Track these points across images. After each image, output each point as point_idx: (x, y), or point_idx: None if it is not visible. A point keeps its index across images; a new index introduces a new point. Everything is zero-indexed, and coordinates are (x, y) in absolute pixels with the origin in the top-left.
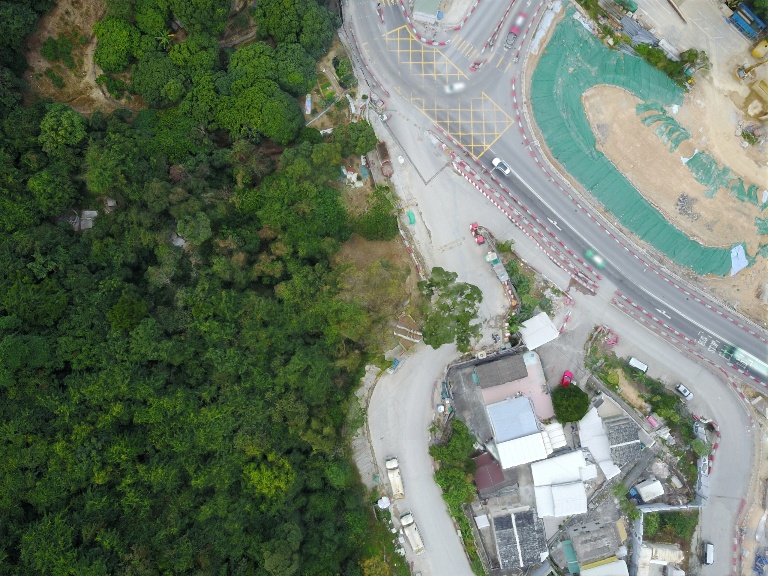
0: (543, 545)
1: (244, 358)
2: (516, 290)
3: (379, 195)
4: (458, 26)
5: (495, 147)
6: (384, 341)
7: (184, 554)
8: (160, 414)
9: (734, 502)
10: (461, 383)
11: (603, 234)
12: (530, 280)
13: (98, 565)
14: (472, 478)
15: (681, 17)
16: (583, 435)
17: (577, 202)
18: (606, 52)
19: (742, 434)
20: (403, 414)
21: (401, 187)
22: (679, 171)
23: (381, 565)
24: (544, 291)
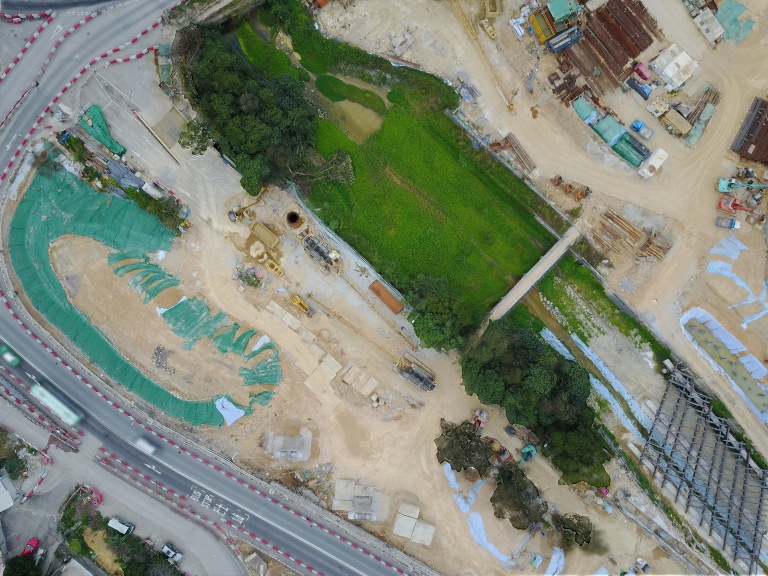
0: None
1: None
2: None
3: None
4: None
5: None
6: None
7: None
8: None
9: None
10: None
11: (86, 387)
12: None
13: None
14: None
15: (174, 158)
16: None
17: (56, 355)
18: (93, 196)
19: None
20: None
21: None
22: (154, 323)
23: None
24: (18, 451)
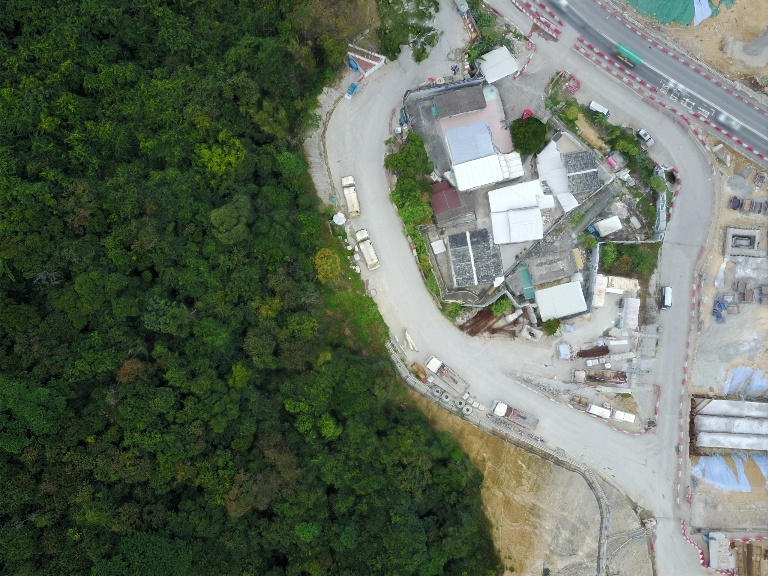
0: (499, 270)
1: (196, 42)
2: (476, 22)
3: None
4: None
5: None
6: (336, 27)
7: (129, 197)
8: (110, 79)
9: (694, 250)
10: (420, 116)
11: None
12: (492, 22)
13: (40, 185)
14: (428, 198)
15: None
16: (541, 169)
17: None
18: None
19: (703, 183)
20: (361, 139)
21: None
22: None
23: (332, 257)
24: (506, 35)
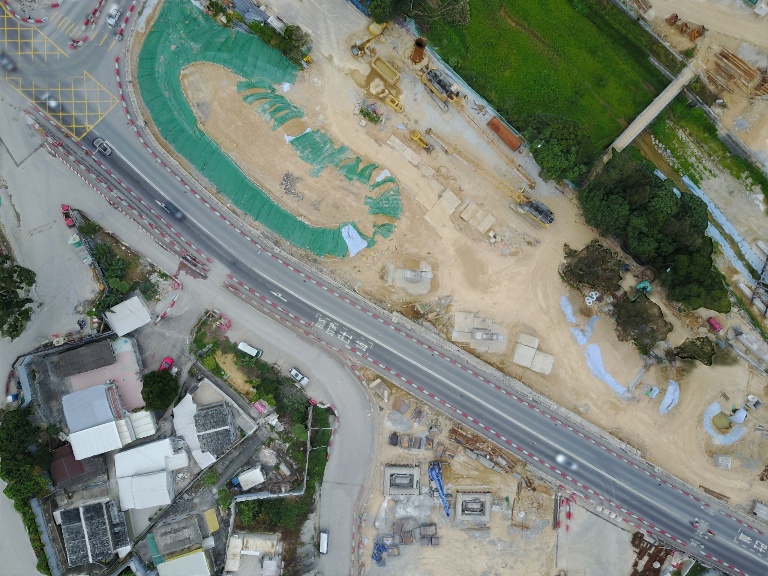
0: (124, 539)
1: None
2: (103, 274)
3: None
4: (56, 3)
5: (98, 127)
6: None
7: None
8: None
9: (354, 489)
10: (48, 372)
11: (214, 216)
12: (133, 264)
13: None
14: (41, 471)
15: None
16: (177, 423)
17: (185, 183)
18: (218, 30)
19: (362, 418)
20: None
21: None
22: (283, 150)
23: None
24: (150, 275)
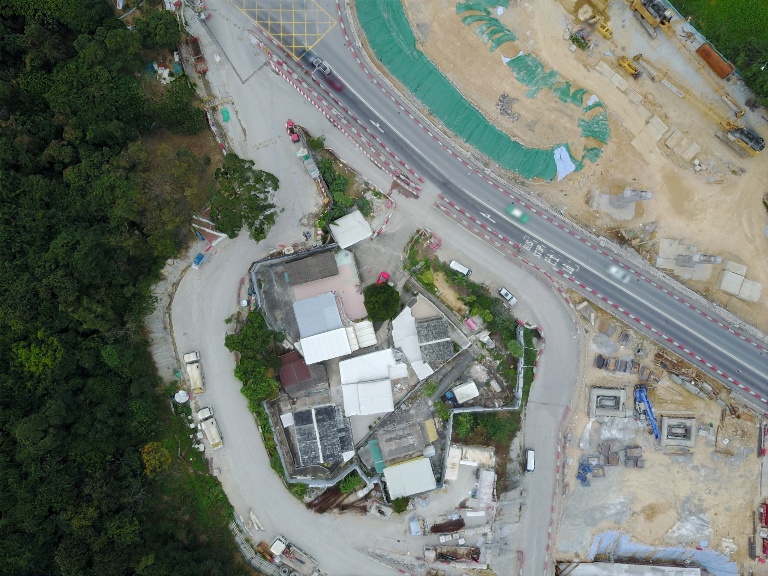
0: (349, 444)
1: (17, 236)
2: (328, 187)
3: (175, 82)
4: None
5: (317, 48)
6: (161, 220)
7: None
8: None
9: (559, 409)
10: (273, 282)
11: (427, 137)
12: (349, 181)
13: None
14: (274, 373)
15: None
16: (396, 335)
17: (400, 104)
18: None
19: (568, 340)
20: (208, 310)
21: (216, 84)
22: (499, 70)
23: (160, 450)
24: (365, 193)
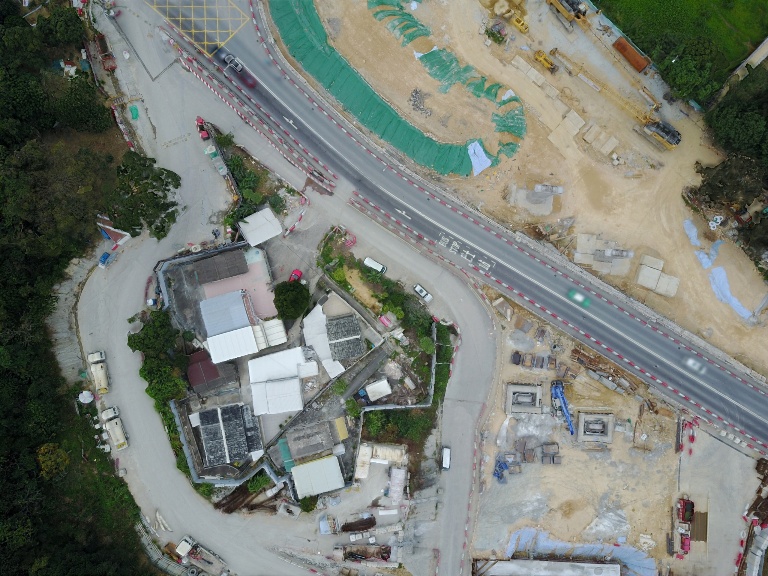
0: (258, 443)
1: None
2: (237, 185)
3: None
4: None
5: (229, 44)
6: (53, 218)
7: None
8: None
9: (476, 406)
10: (183, 281)
11: (341, 133)
12: (262, 178)
13: None
14: (180, 373)
15: None
16: (307, 333)
17: (313, 100)
18: None
19: (484, 337)
20: (115, 309)
21: (124, 82)
22: (411, 66)
23: (56, 452)
24: (278, 190)
